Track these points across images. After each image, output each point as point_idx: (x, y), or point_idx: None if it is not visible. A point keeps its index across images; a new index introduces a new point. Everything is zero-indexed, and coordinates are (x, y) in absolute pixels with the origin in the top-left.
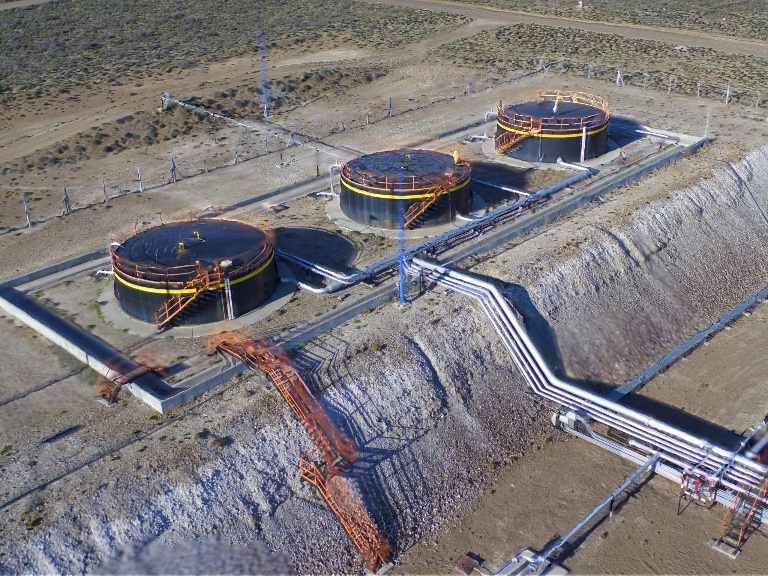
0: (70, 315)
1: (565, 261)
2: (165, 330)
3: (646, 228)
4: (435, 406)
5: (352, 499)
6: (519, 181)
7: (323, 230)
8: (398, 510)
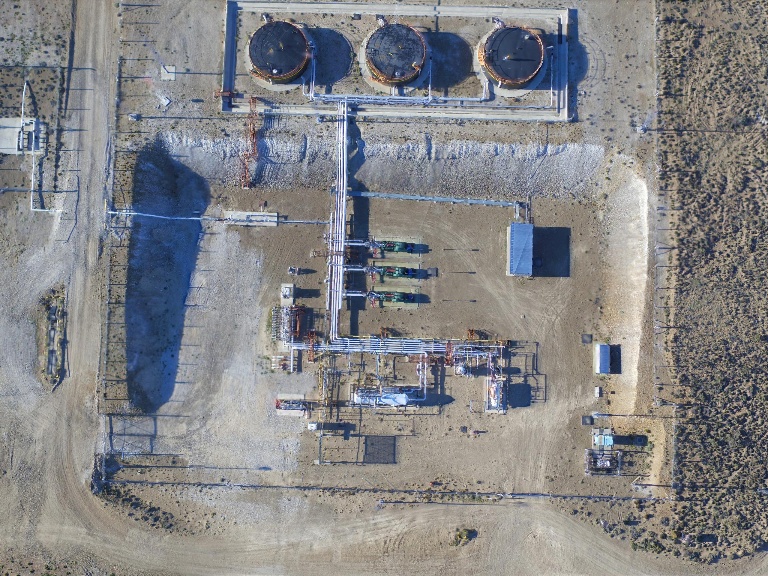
0: (238, 38)
1: (393, 143)
2: None
3: (451, 149)
4: (297, 159)
5: (254, 167)
6: (457, 78)
7: (352, 49)
8: (264, 177)
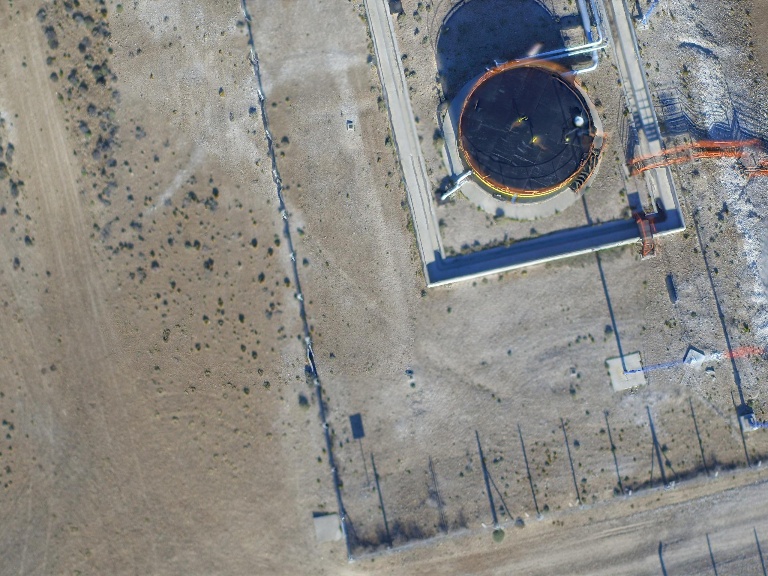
0: (507, 240)
1: None
2: (576, 188)
3: None
4: (718, 66)
5: None
6: None
7: None
8: (761, 136)
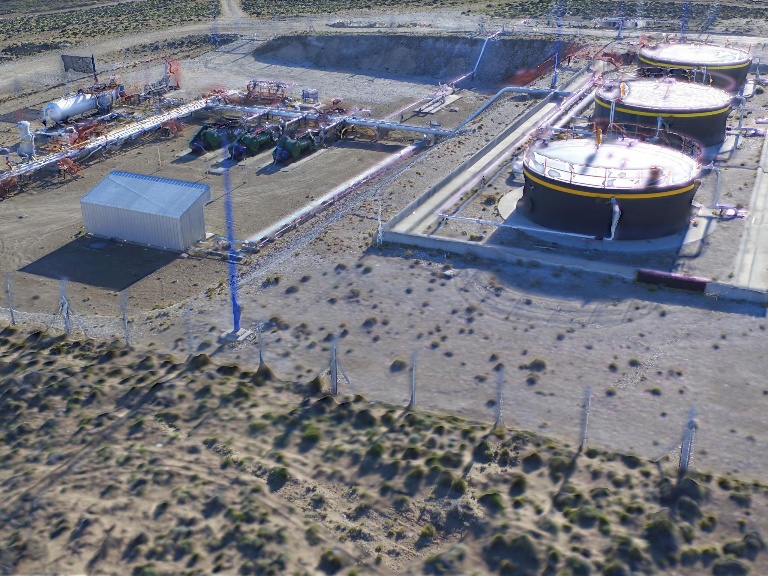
0: None
1: None
2: None
3: None
4: None
5: None
6: None
7: None
8: None
